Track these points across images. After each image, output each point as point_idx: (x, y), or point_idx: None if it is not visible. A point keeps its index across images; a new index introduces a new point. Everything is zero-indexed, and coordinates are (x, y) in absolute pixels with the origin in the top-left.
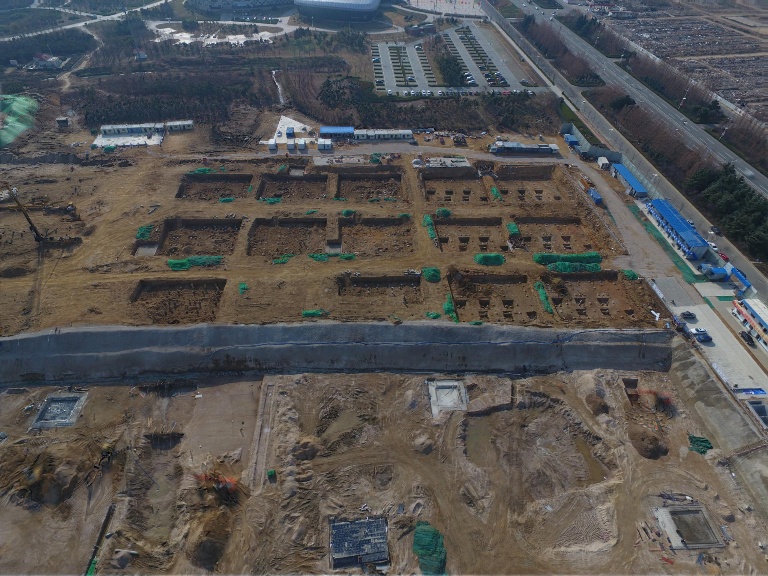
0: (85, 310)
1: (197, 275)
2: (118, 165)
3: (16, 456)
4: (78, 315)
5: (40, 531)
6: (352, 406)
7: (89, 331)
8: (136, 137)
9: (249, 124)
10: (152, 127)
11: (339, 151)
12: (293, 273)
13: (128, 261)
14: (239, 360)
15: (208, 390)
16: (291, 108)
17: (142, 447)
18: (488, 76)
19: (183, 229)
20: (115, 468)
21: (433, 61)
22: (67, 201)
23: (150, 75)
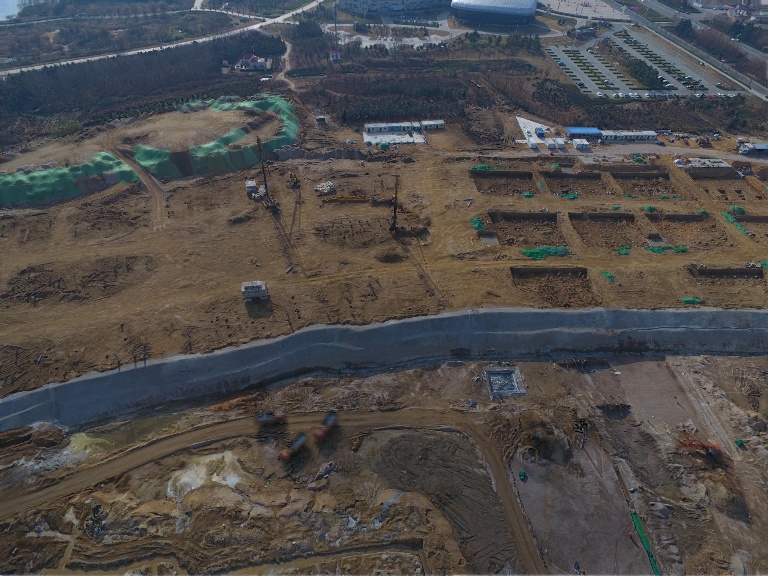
0: (483, 293)
1: (557, 264)
2: (402, 161)
3: (503, 420)
4: (481, 297)
5: (569, 485)
6: (767, 385)
7: (503, 312)
8: (399, 135)
9: (493, 124)
10: (410, 126)
11: (597, 151)
12: (643, 264)
13: (484, 250)
14: (640, 341)
15: (622, 368)
16: (518, 109)
17: (602, 416)
18: (681, 80)
19: (504, 222)
20: (593, 433)
21: (619, 64)
22: (383, 194)
23: (368, 76)
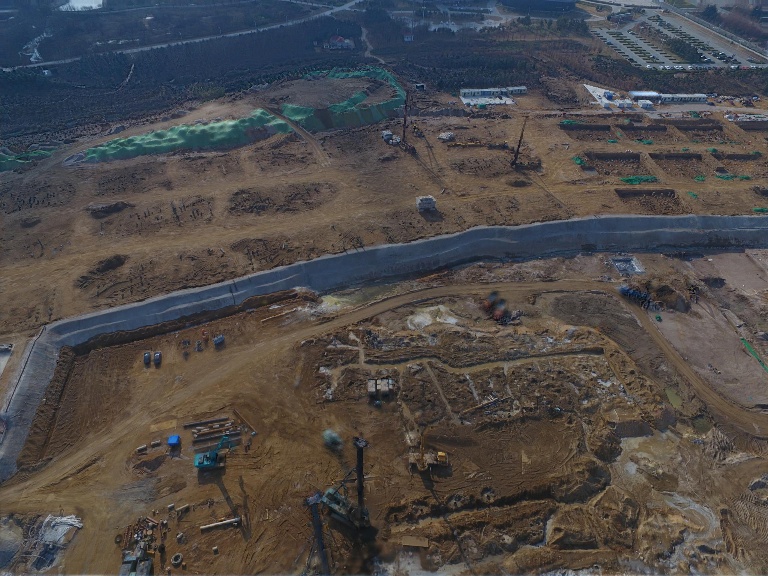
0: (600, 206)
1: (651, 187)
2: (501, 118)
3: (635, 286)
4: (599, 208)
5: (692, 323)
6: None
7: (619, 217)
8: (490, 98)
9: (566, 90)
10: (499, 91)
11: (659, 109)
12: (718, 187)
13: (590, 178)
14: (725, 239)
15: (713, 257)
16: (583, 79)
17: None
18: (716, 55)
19: (598, 160)
20: (702, 295)
21: (660, 43)
22: (494, 141)
23: (447, 53)
